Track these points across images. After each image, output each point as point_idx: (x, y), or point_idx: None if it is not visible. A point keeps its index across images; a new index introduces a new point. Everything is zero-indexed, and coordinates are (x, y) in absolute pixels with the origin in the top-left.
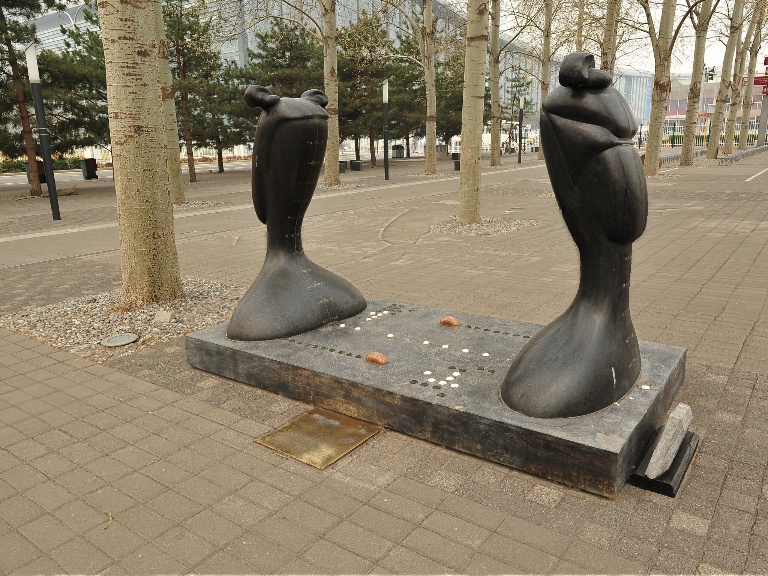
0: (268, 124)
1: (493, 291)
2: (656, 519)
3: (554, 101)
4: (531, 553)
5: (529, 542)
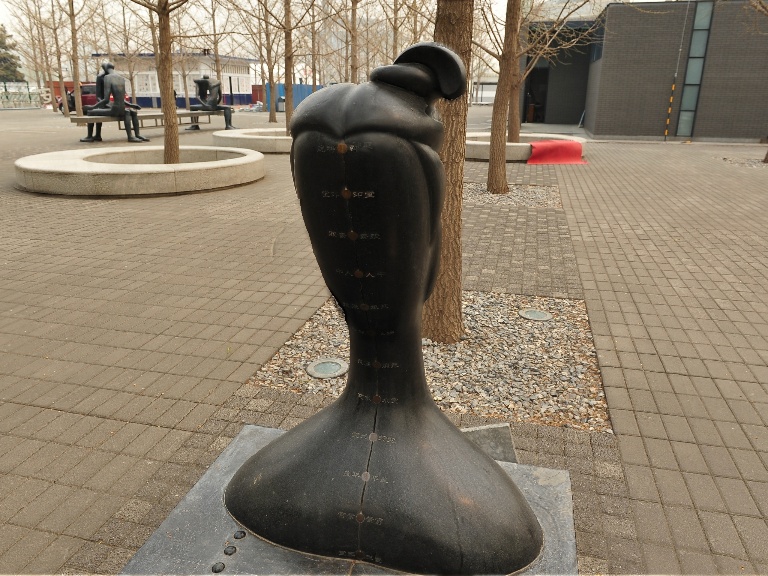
0: None
1: None
2: None
3: (426, 122)
4: (692, 568)
5: (679, 571)
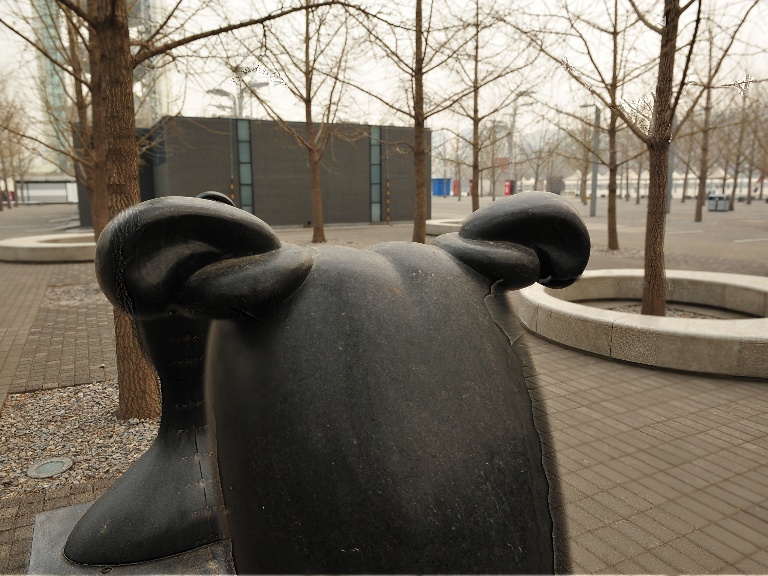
0: None
1: None
2: None
3: None
4: None
5: None
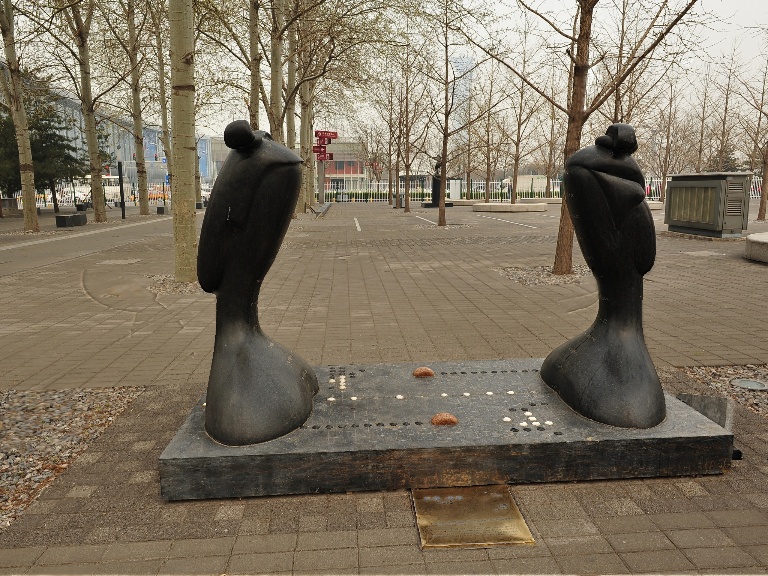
0: (254, 168)
1: (345, 343)
2: (761, 476)
3: (601, 161)
4: (762, 530)
5: (748, 523)
